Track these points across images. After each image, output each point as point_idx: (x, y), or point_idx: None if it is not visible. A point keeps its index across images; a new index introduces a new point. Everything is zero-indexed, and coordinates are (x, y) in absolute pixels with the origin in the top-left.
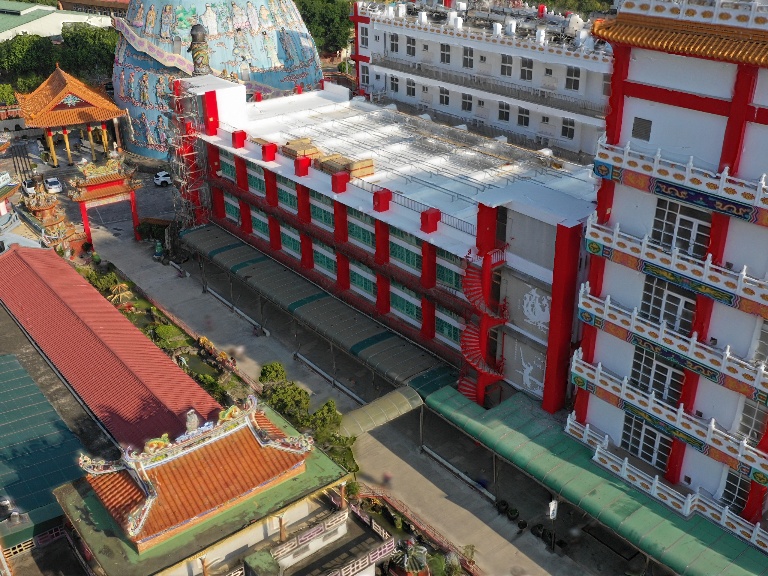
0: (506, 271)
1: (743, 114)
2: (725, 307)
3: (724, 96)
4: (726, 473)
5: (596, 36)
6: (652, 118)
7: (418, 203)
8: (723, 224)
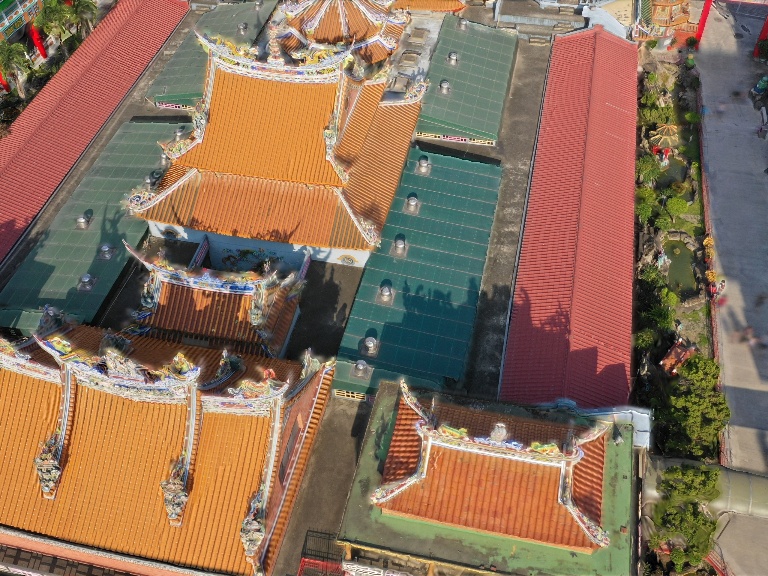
0: None
1: None
2: None
3: None
4: None
5: None
6: None
7: None
8: None
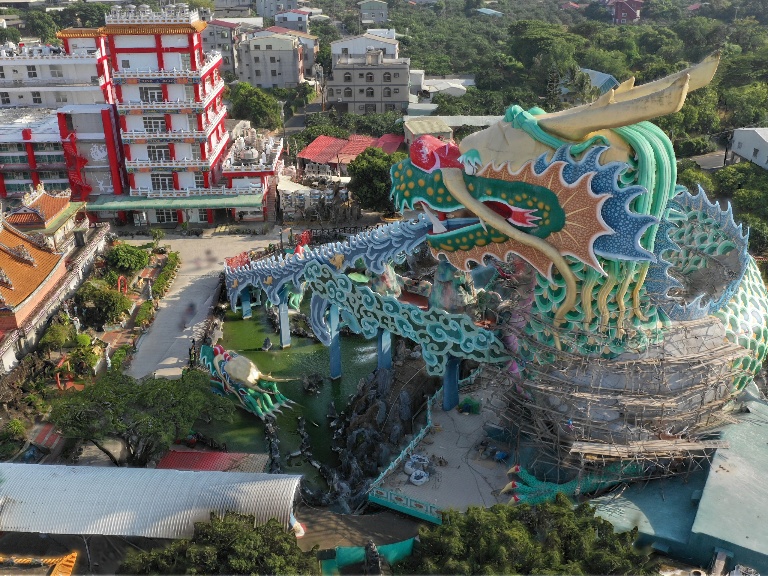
0: (79, 142)
1: (161, 51)
2: (175, 117)
3: (152, 47)
4: (195, 178)
5: (33, 50)
6: (129, 59)
7: (15, 130)
8: (166, 88)
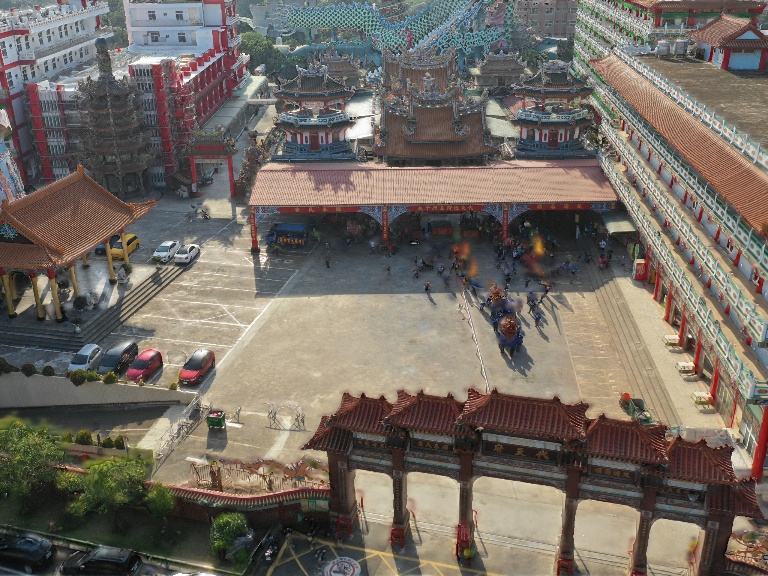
0: None
1: None
2: None
3: None
4: None
5: None
6: None
7: None
8: None
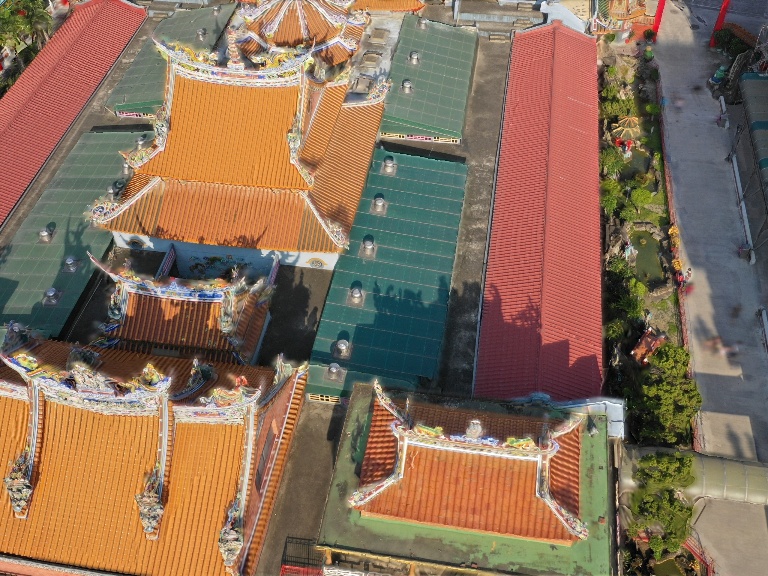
0: None
1: None
2: None
3: None
4: None
5: None
6: None
7: None
8: None
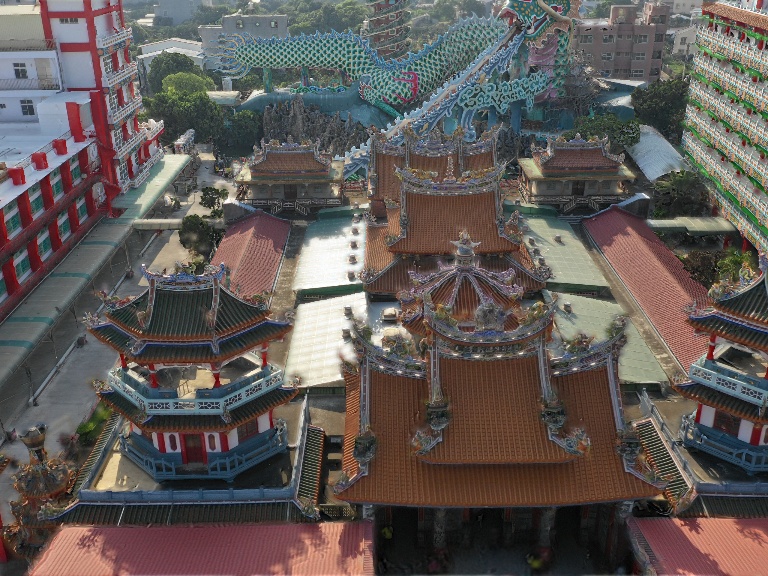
0: None
1: None
2: None
3: None
4: None
5: None
6: None
7: None
8: None
